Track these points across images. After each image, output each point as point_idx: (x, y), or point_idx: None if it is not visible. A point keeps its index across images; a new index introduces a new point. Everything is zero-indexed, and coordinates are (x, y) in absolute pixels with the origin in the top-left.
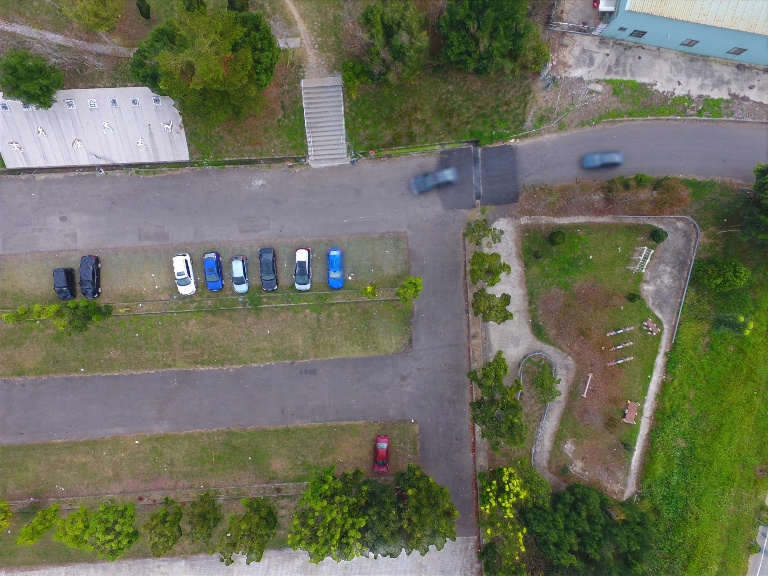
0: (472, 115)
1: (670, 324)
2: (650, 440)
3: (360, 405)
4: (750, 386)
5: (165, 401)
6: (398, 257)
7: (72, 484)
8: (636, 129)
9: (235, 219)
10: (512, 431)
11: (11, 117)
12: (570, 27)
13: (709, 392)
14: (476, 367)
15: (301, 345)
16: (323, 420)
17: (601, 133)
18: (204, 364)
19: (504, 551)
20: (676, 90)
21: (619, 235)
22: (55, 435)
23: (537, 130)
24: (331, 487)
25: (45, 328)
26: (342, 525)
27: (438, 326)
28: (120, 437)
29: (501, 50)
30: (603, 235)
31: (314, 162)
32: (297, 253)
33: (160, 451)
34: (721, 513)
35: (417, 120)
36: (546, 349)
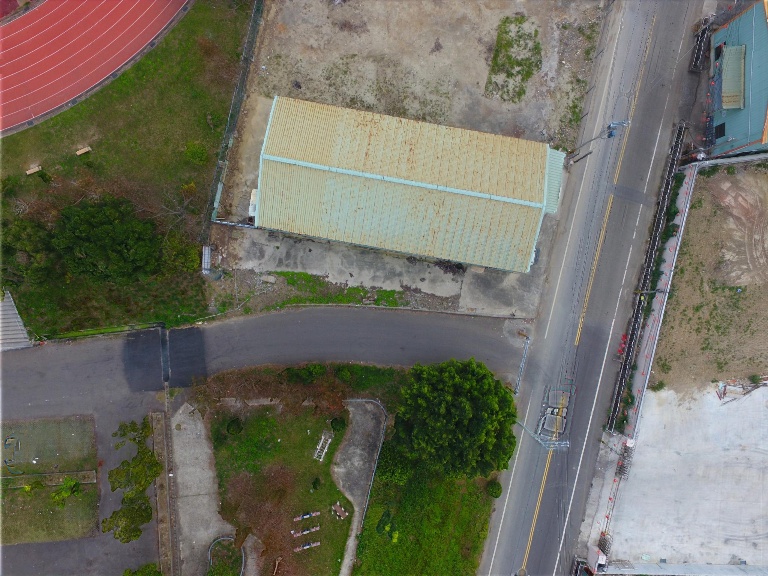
0: (151, 302)
1: (361, 507)
2: None
3: None
4: None
5: None
6: (85, 440)
7: None
8: (319, 314)
9: None
10: None
11: None
12: (240, 220)
13: None
14: (164, 552)
15: None
16: None
17: (286, 317)
18: None
19: None
20: (348, 282)
21: (308, 417)
22: None
23: (223, 313)
24: None
25: None
26: None
27: None
28: None
29: (121, 270)
30: (292, 417)
31: None
32: None
33: None
34: None
35: (94, 307)
36: None
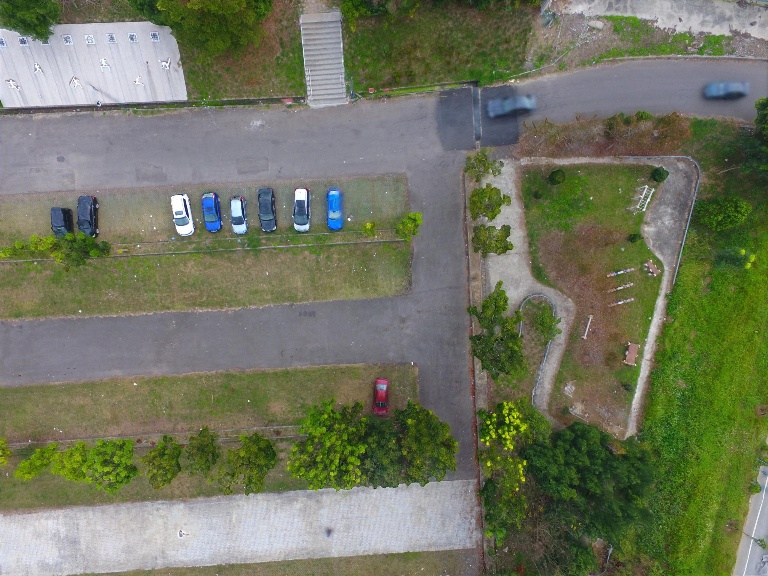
0: (472, 54)
1: (671, 266)
2: (650, 382)
3: (359, 347)
4: (751, 325)
5: (163, 343)
6: (397, 198)
7: (70, 426)
8: (637, 68)
9: (234, 160)
10: (512, 360)
11: (8, 53)
12: None
13: (710, 332)
14: None
15: (300, 287)
16: (322, 363)
17: (602, 73)
18: (203, 306)
19: (504, 483)
20: (677, 27)
21: (620, 176)
22: (53, 377)
23: (537, 70)
24: (330, 417)
25: (43, 269)
26: (341, 452)
27: (438, 268)
28: (118, 379)
29: None
30: (603, 176)
31: (313, 102)
32: (296, 192)
33: (159, 393)
34: (722, 452)
35: (417, 58)
36: (546, 291)
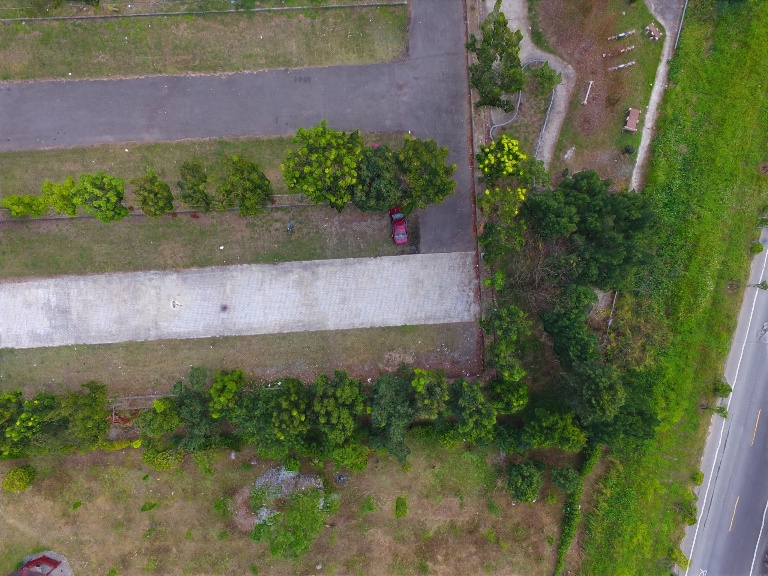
0: None
1: (673, 31)
2: (651, 149)
3: (356, 115)
4: (754, 79)
5: (155, 108)
6: None
7: None
8: None
9: None
10: None
11: None
12: None
13: (712, 92)
14: None
15: (295, 52)
16: None
17: None
18: (195, 70)
19: (503, 208)
20: None
21: None
22: (42, 142)
23: None
24: None
25: (31, 29)
26: (337, 154)
27: (436, 34)
28: (109, 145)
29: None
30: None
31: None
32: None
33: (151, 160)
34: (723, 210)
35: None
36: (546, 58)
